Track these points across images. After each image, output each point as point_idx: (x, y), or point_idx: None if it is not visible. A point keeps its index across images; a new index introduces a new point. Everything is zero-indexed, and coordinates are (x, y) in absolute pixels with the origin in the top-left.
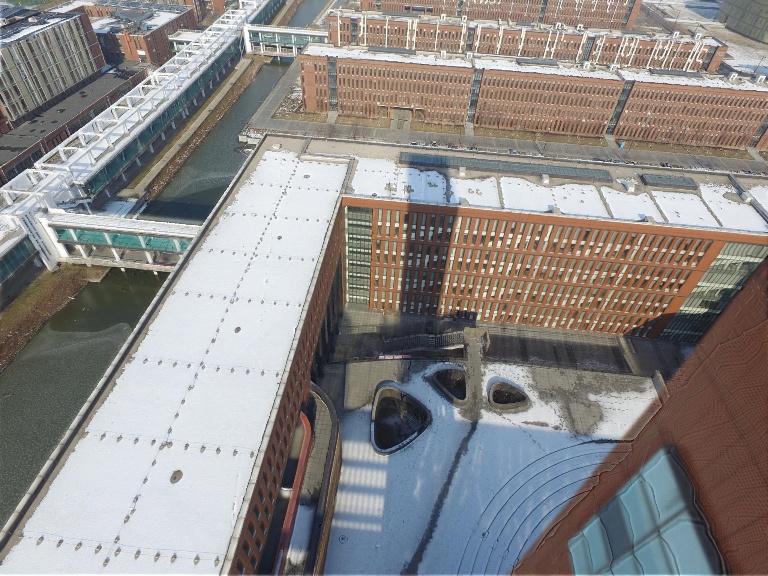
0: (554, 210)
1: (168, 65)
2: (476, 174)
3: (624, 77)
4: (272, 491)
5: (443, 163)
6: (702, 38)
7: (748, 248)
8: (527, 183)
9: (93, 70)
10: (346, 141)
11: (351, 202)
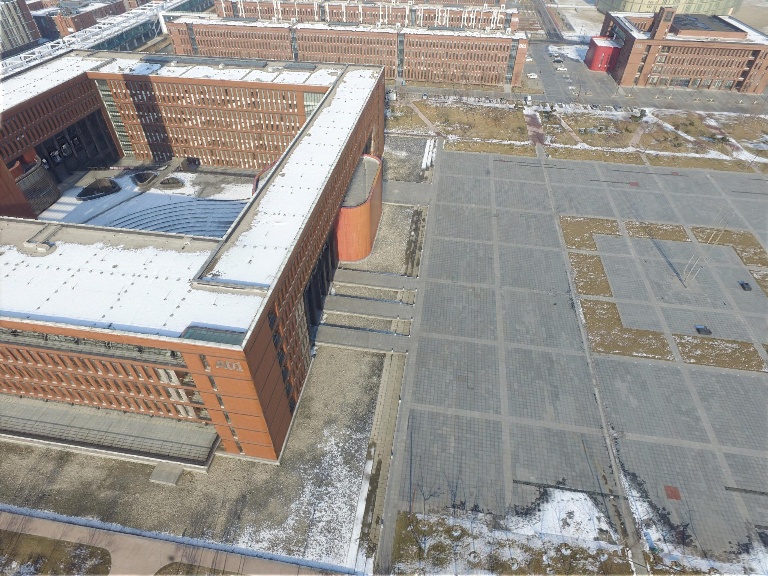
0: (203, 76)
1: (77, 34)
2: (183, 65)
3: (401, 32)
4: None
5: (166, 60)
6: (507, 8)
7: (319, 97)
8: (209, 68)
9: (29, 40)
10: (119, 52)
11: (92, 75)
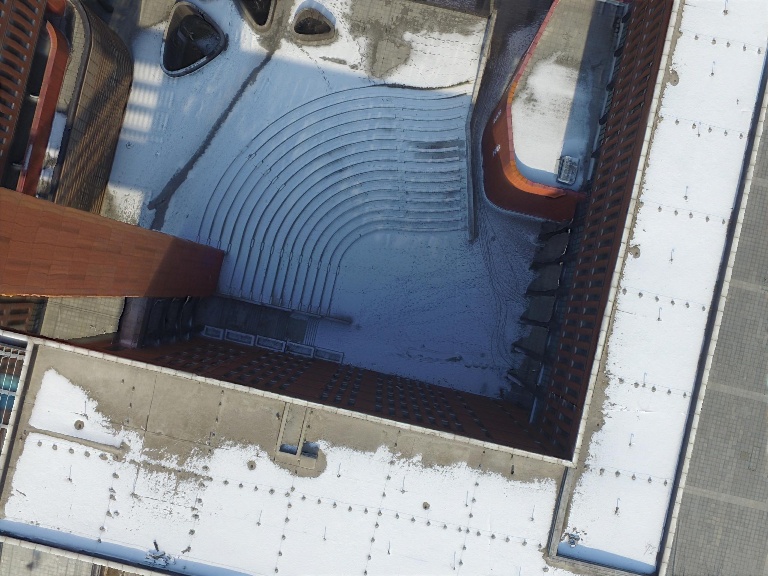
0: None
1: None
2: None
3: None
4: (3, 96)
5: None
6: None
7: None
8: None
9: None
10: None
11: None
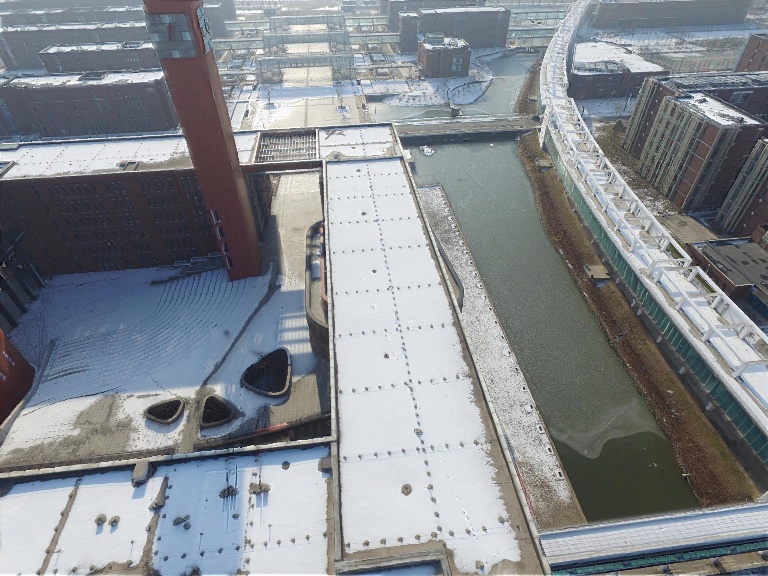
0: None
1: None
2: None
3: None
4: None
5: None
6: None
7: None
8: None
9: None
10: None
11: None
